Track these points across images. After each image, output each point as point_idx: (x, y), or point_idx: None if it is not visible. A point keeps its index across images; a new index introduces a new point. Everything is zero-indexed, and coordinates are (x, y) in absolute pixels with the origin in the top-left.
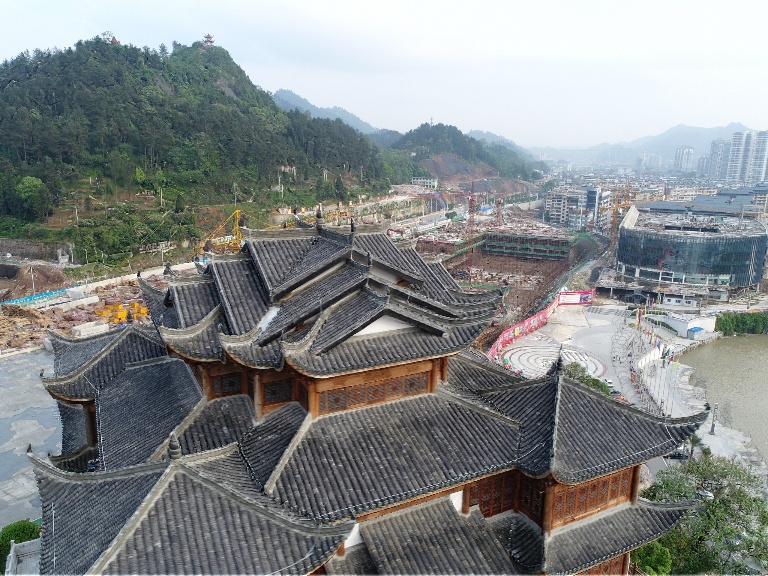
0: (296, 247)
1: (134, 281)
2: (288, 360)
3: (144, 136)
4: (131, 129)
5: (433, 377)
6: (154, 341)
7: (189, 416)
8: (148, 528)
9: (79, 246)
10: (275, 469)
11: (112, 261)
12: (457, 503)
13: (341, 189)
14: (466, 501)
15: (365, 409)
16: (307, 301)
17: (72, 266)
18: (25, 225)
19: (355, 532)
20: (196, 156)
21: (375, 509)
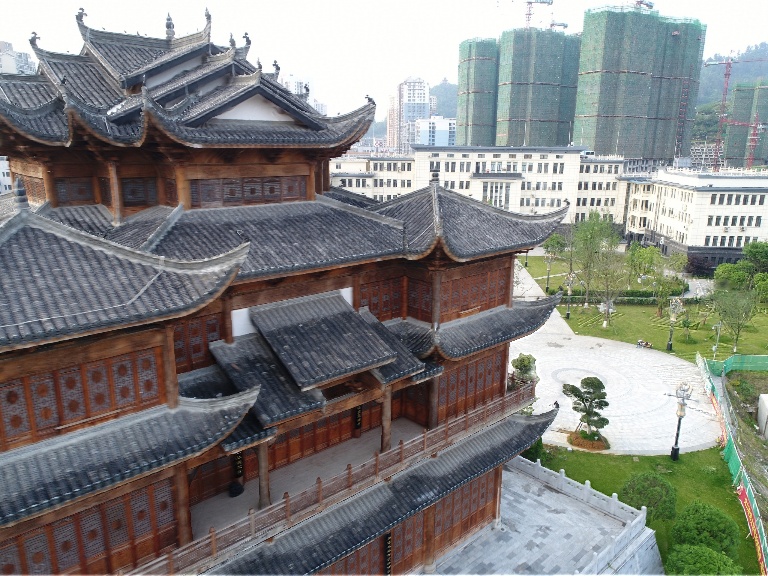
0: None
1: None
2: None
3: None
4: None
5: None
6: (401, 201)
7: None
8: None
9: None
10: None
11: None
12: None
13: None
14: None
15: None
16: None
17: None
18: None
19: None
20: None
21: None
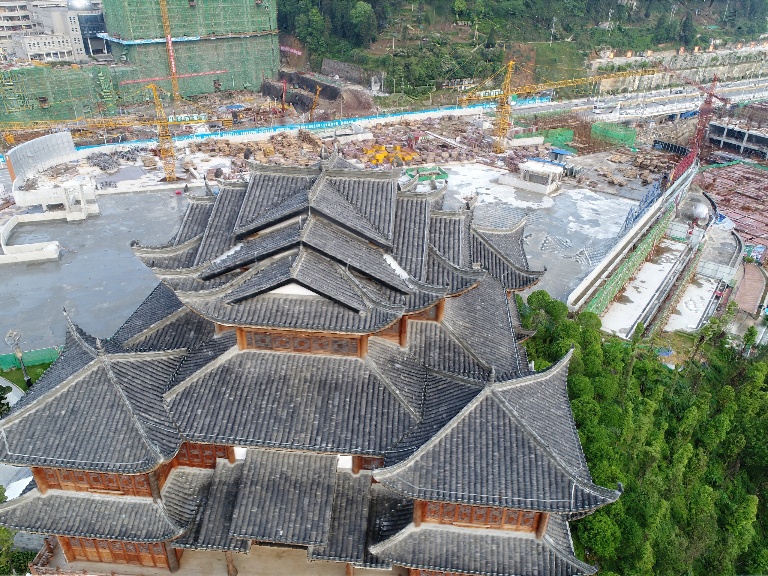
0: (291, 186)
1: (410, 122)
2: (187, 305)
3: None
4: None
5: (362, 345)
6: None
7: (172, 315)
8: (63, 399)
9: (390, 75)
10: (179, 384)
11: (416, 93)
12: (347, 462)
13: (688, 31)
14: (354, 464)
15: (289, 355)
16: (254, 248)
17: (381, 94)
18: (352, 50)
19: (244, 451)
20: None
21: (234, 444)
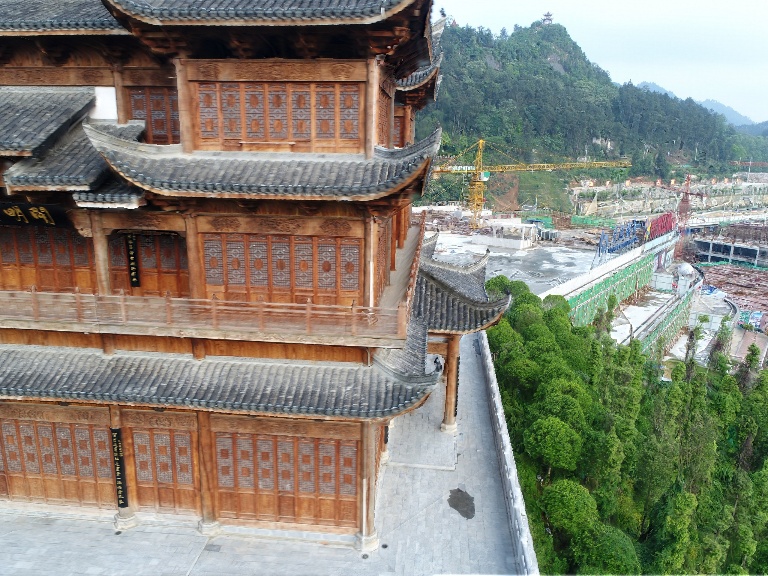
0: None
1: None
2: None
3: (455, 103)
4: (445, 97)
5: None
6: None
7: None
8: None
9: None
10: None
11: None
12: (109, 106)
13: (662, 165)
14: (117, 103)
15: None
16: None
17: None
18: None
19: None
20: (501, 123)
21: None
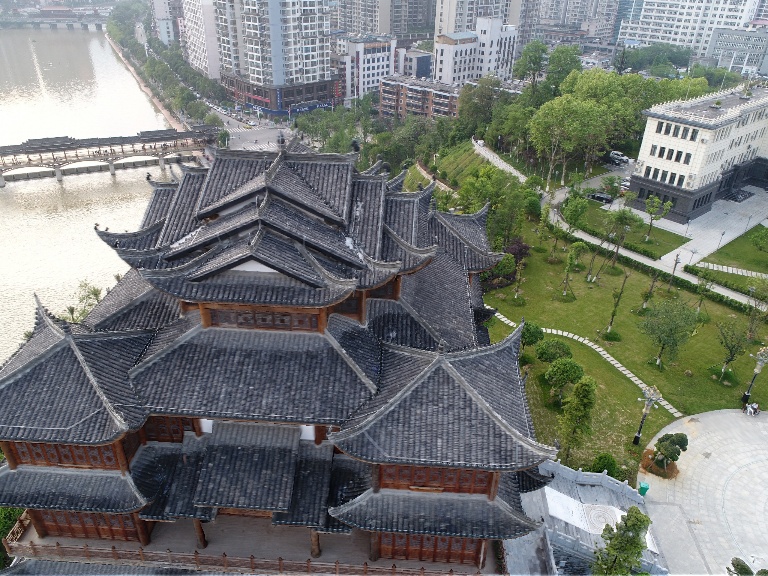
0: None
1: None
2: None
3: None
4: None
5: None
6: None
7: None
8: None
9: None
10: None
11: None
12: None
13: None
14: None
15: None
16: None
17: None
18: None
19: None
20: None
21: None
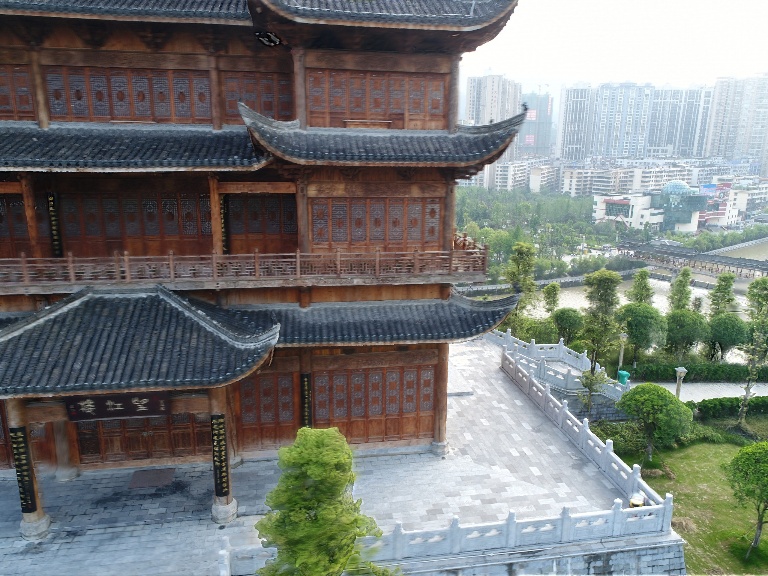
0: None
1: None
2: None
3: None
4: None
5: None
6: None
7: None
8: None
9: None
10: None
11: None
12: None
13: None
14: None
15: None
16: None
17: None
18: None
19: None
20: None
21: None
